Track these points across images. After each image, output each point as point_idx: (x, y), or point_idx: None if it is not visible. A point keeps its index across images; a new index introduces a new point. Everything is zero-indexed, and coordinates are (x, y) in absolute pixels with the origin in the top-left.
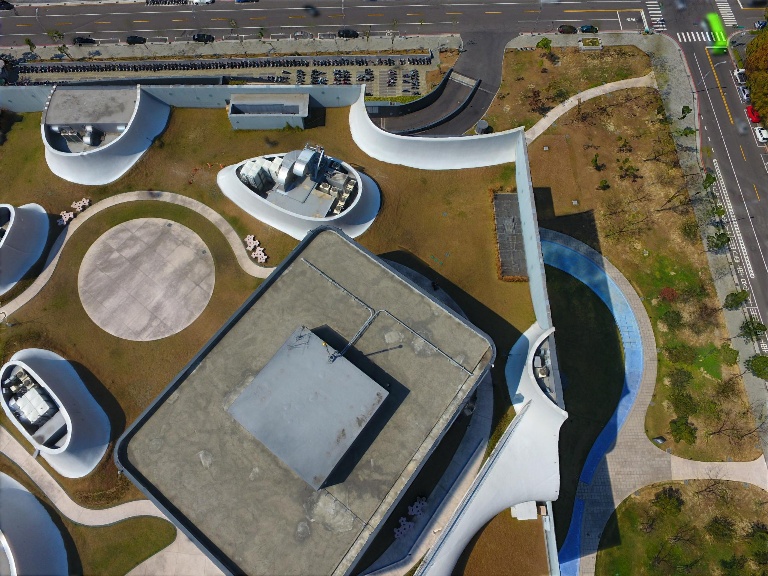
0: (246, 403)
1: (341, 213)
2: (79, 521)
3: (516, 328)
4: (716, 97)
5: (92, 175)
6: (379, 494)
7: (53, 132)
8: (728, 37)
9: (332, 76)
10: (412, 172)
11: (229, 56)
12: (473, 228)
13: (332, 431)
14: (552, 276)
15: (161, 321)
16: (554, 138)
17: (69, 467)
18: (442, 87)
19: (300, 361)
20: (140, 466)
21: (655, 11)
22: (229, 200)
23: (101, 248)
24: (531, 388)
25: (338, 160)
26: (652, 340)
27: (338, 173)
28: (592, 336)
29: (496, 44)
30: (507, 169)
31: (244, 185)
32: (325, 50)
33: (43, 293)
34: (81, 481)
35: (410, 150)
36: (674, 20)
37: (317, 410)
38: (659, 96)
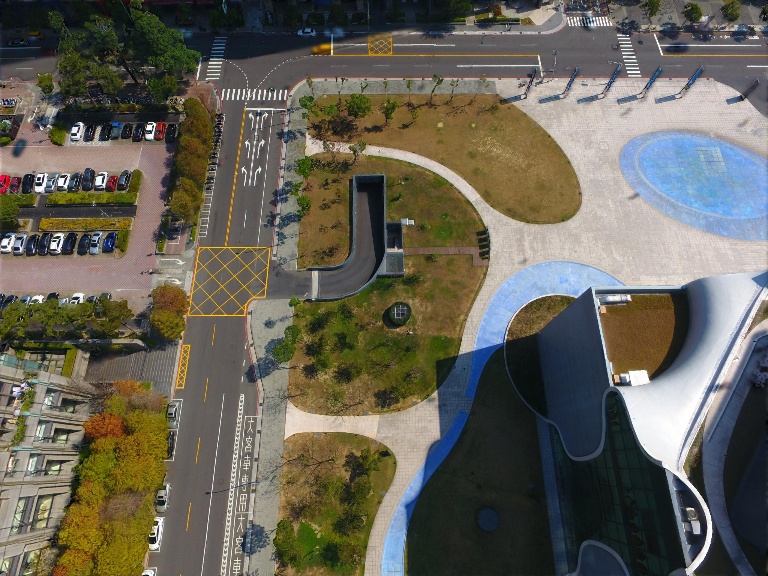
0: None
1: None
2: None
3: None
4: None
5: None
6: None
7: None
8: None
9: None
10: None
11: None
12: None
13: None
14: None
15: None
16: None
17: None
18: None
19: None
20: None
21: None
22: None
23: None
24: None
25: None
26: (368, 575)
27: None
28: None
29: None
30: None
31: None
32: None
33: None
34: None
35: None
36: None
37: None
38: None
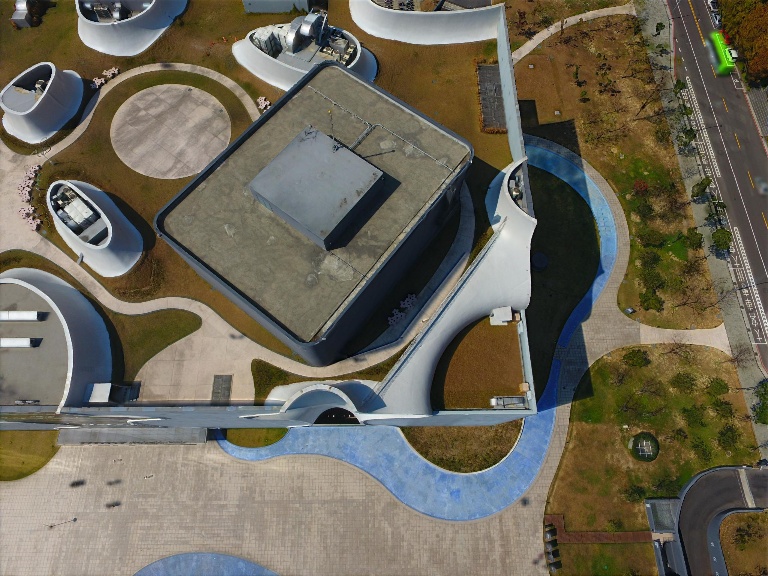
0: (264, 179)
1: None
2: (118, 311)
3: (495, 168)
4: (690, 23)
5: (121, 47)
6: (375, 255)
7: (86, 9)
8: None
9: None
10: (405, 47)
11: None
12: (459, 92)
13: (336, 199)
14: (535, 175)
15: (184, 164)
16: (539, 58)
17: (109, 266)
18: None
19: (309, 150)
20: (175, 235)
21: None
22: (243, 67)
23: (130, 107)
24: (506, 204)
25: (339, 29)
26: (625, 229)
27: (339, 39)
28: (571, 225)
29: None
30: (490, 45)
31: (257, 48)
32: None
33: (80, 141)
34: (119, 279)
35: (403, 25)
36: None
37: (323, 185)
38: (637, 22)
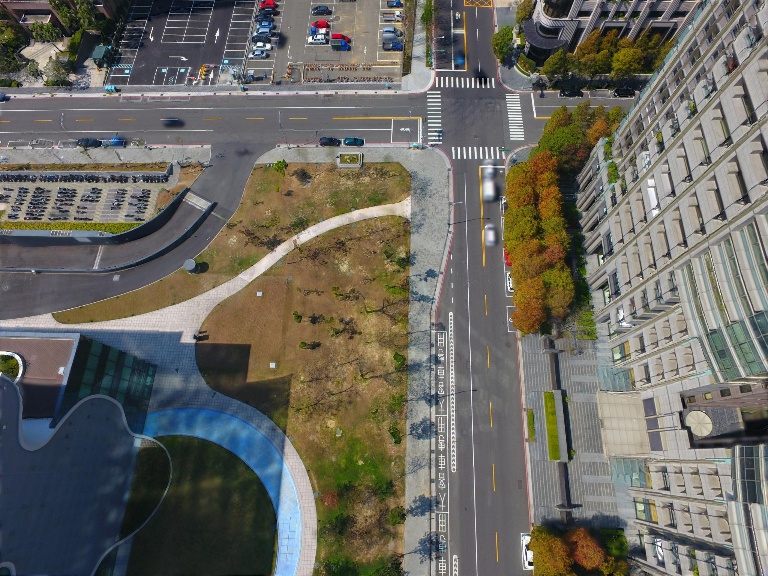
0: None
1: None
2: None
3: None
4: (475, 231)
5: None
6: None
7: None
8: (509, 154)
9: (56, 194)
10: None
11: None
12: None
13: None
14: (220, 461)
15: None
16: (274, 280)
17: None
18: (173, 210)
19: None
20: None
21: (435, 120)
22: None
23: None
24: None
25: None
26: (312, 552)
27: None
28: (244, 543)
29: (247, 158)
30: None
31: None
32: (60, 162)
33: None
34: None
35: None
36: (453, 131)
37: None
38: (409, 228)
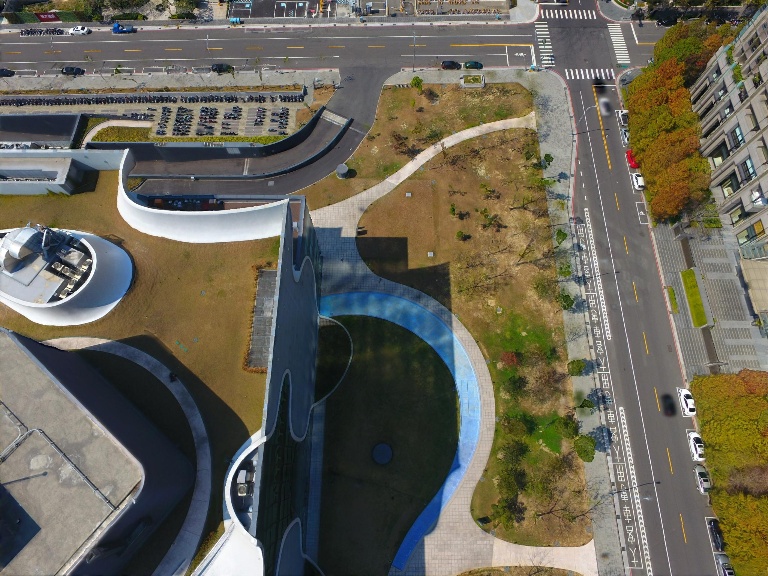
0: None
1: (65, 298)
2: None
3: (247, 429)
4: (597, 140)
5: None
6: None
7: None
8: (618, 75)
9: (199, 113)
10: (174, 245)
11: (96, 91)
12: (230, 309)
13: None
14: (395, 335)
15: None
16: (419, 183)
17: None
18: (312, 126)
19: None
20: None
21: (546, 46)
22: None
23: None
24: None
25: (77, 236)
26: (492, 408)
27: (74, 251)
28: (428, 403)
29: (375, 80)
30: (279, 242)
31: None
32: (196, 85)
33: None
34: None
35: (168, 223)
36: (564, 56)
37: None
38: (537, 138)
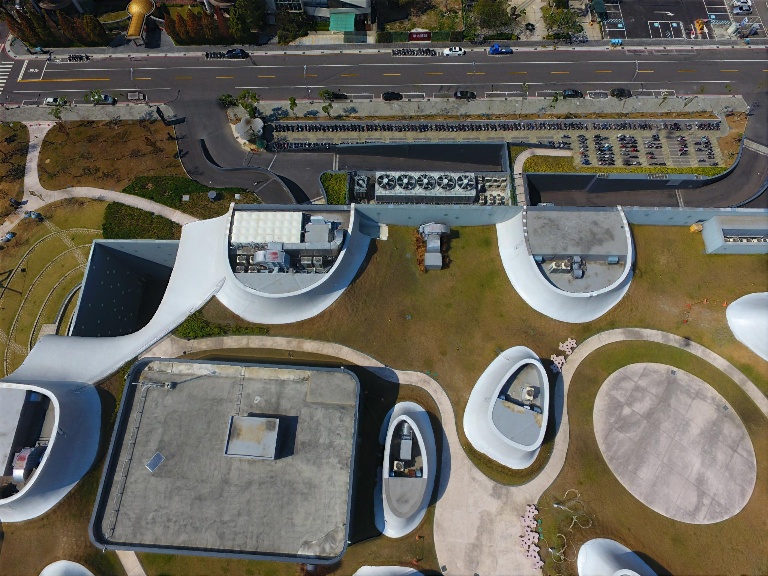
0: None
1: None
2: None
3: None
4: None
5: (580, 312)
6: None
7: None
8: None
9: (616, 142)
10: None
11: (497, 116)
12: None
13: None
14: None
15: (712, 498)
16: None
17: None
18: None
19: None
20: None
21: None
22: (743, 345)
23: (608, 401)
24: None
25: None
26: None
27: None
28: None
29: None
30: None
31: None
32: (600, 111)
33: (569, 461)
34: None
35: None
36: None
37: None
38: None
